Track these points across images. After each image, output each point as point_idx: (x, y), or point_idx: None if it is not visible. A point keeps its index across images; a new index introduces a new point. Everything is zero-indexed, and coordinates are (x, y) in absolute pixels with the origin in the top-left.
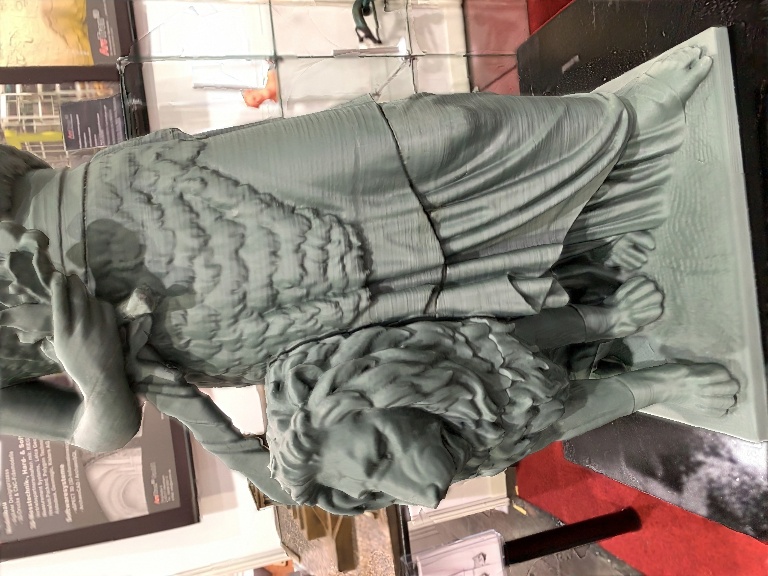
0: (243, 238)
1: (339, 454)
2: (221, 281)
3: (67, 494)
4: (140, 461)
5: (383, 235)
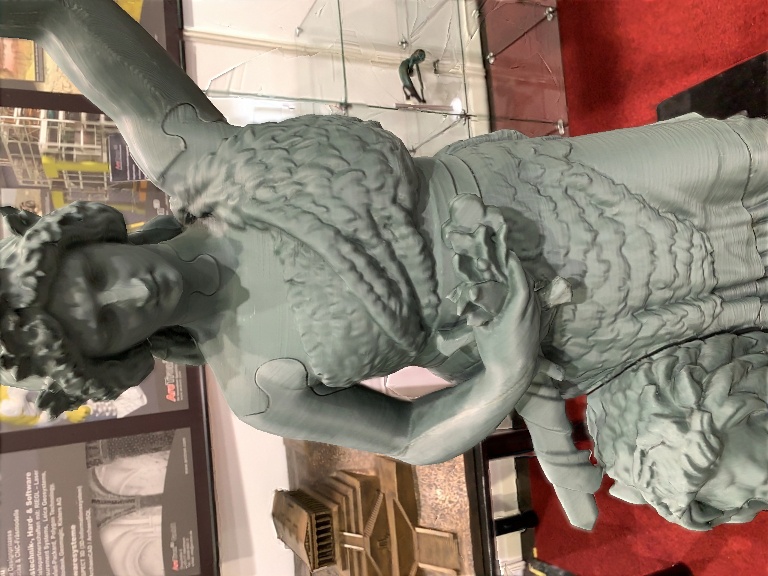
0: (624, 236)
1: (740, 457)
2: (610, 277)
3: (76, 560)
4: (160, 521)
5: (724, 244)
